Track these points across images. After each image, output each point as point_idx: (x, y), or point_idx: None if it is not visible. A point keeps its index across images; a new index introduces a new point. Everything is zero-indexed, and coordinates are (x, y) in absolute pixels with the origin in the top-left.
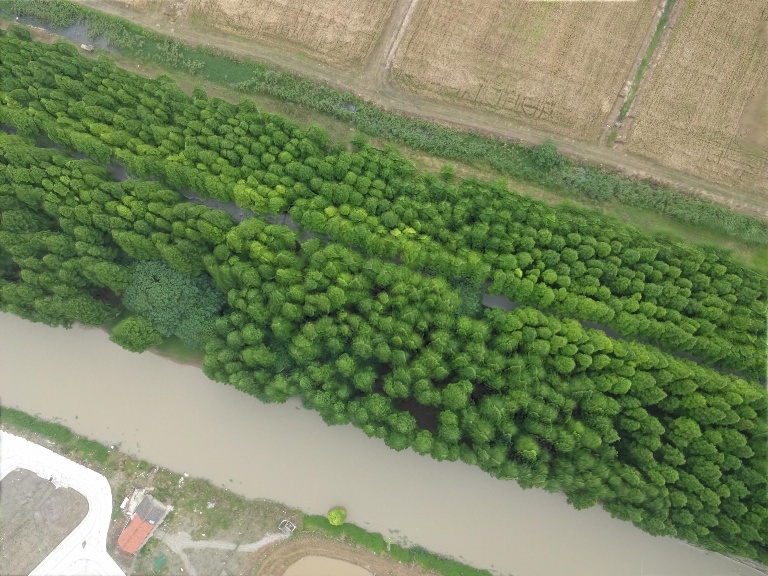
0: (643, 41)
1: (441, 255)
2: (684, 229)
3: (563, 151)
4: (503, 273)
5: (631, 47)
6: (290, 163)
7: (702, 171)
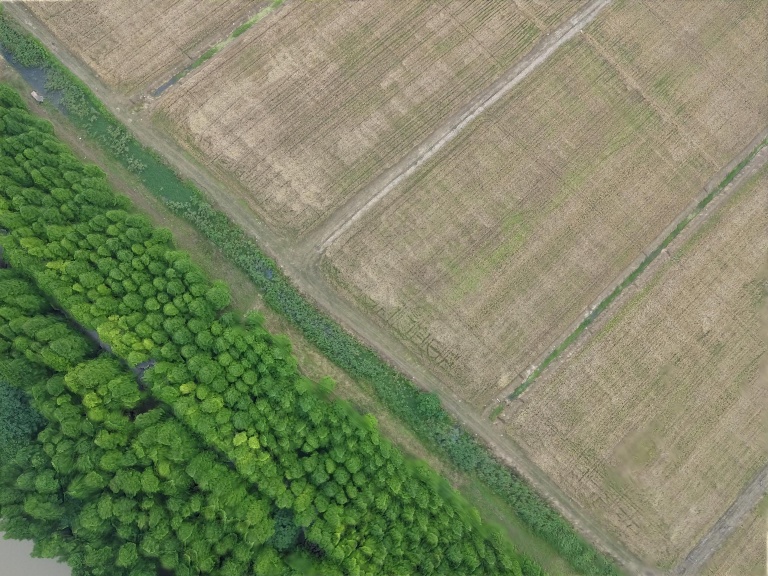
0: (562, 333)
1: (269, 489)
2: (523, 533)
3: (447, 406)
4: (320, 534)
5: (549, 334)
6: (172, 319)
7: (563, 481)
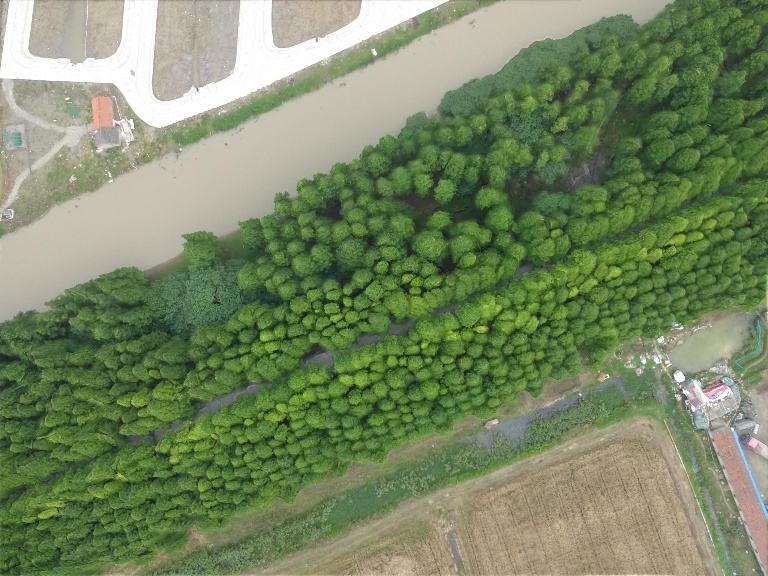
0: None
1: None
2: None
3: None
4: None
5: None
6: (191, 485)
7: None
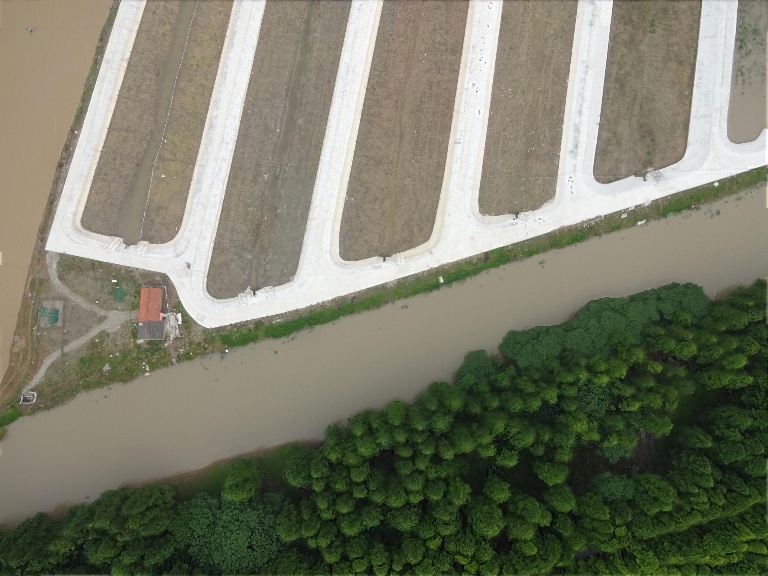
0: None
1: None
2: None
3: None
4: None
5: None
6: None
7: None
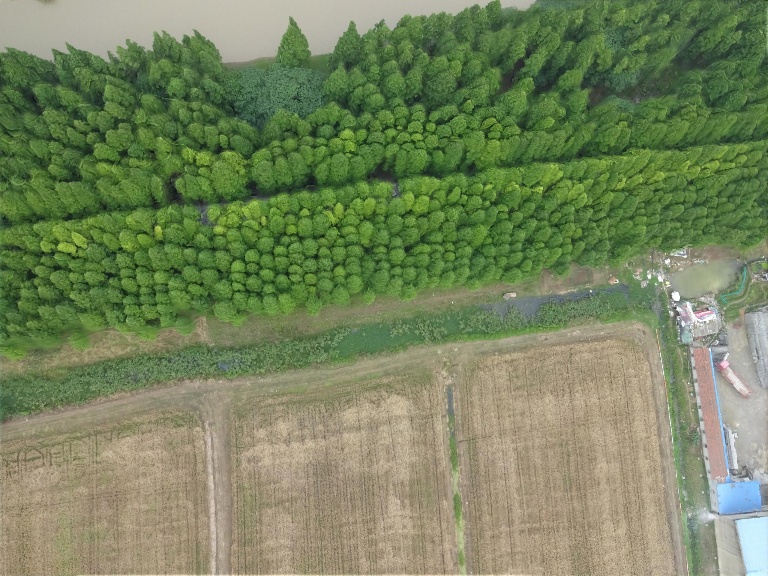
0: None
1: (8, 231)
2: None
3: None
4: None
5: None
6: (227, 262)
7: None
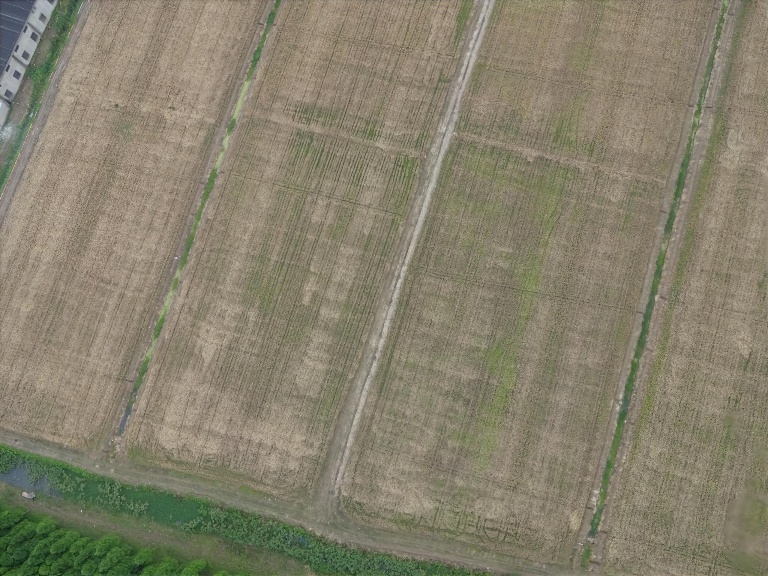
0: (604, 441)
1: None
2: None
3: None
4: None
5: (592, 451)
6: None
7: None
